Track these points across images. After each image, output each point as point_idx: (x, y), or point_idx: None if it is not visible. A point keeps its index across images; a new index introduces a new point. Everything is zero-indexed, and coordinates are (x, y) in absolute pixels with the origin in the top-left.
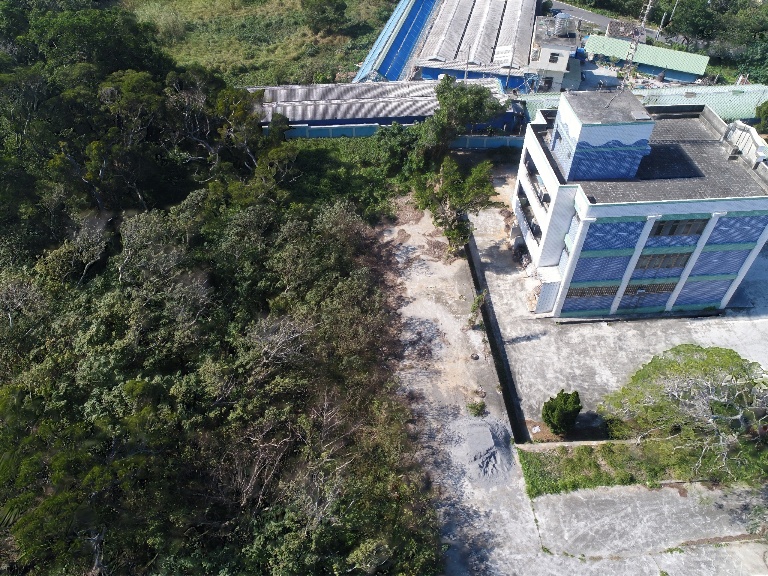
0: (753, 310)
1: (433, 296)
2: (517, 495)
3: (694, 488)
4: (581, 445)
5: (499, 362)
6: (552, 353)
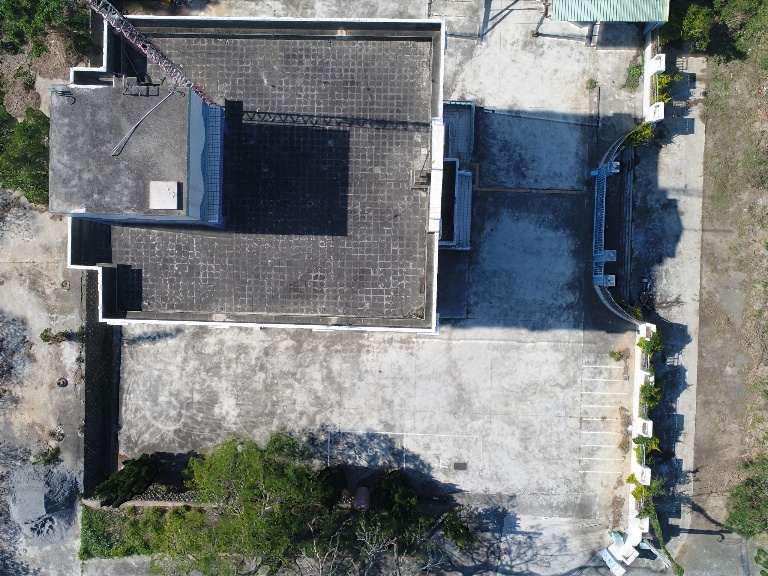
0: (462, 323)
1: (27, 279)
2: (69, 556)
3: (254, 562)
4: (153, 507)
5: (105, 377)
6: (175, 366)
